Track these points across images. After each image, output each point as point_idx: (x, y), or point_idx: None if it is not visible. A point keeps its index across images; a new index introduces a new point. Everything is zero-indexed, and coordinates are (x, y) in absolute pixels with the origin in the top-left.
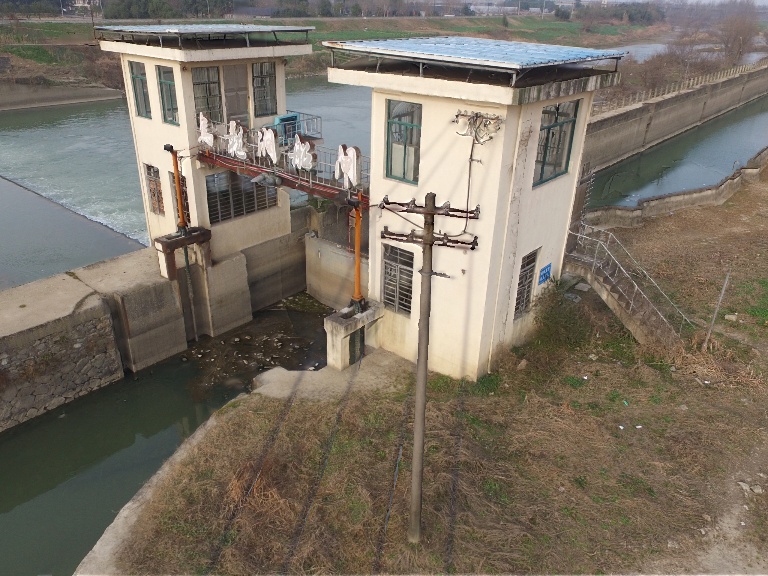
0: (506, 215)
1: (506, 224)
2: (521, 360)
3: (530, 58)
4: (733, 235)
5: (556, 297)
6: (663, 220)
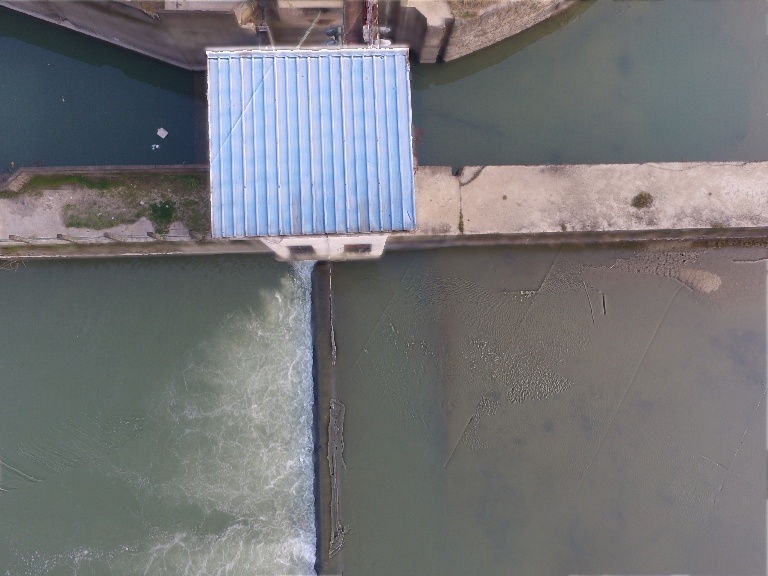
0: None
1: None
2: None
3: None
4: None
5: None
6: None
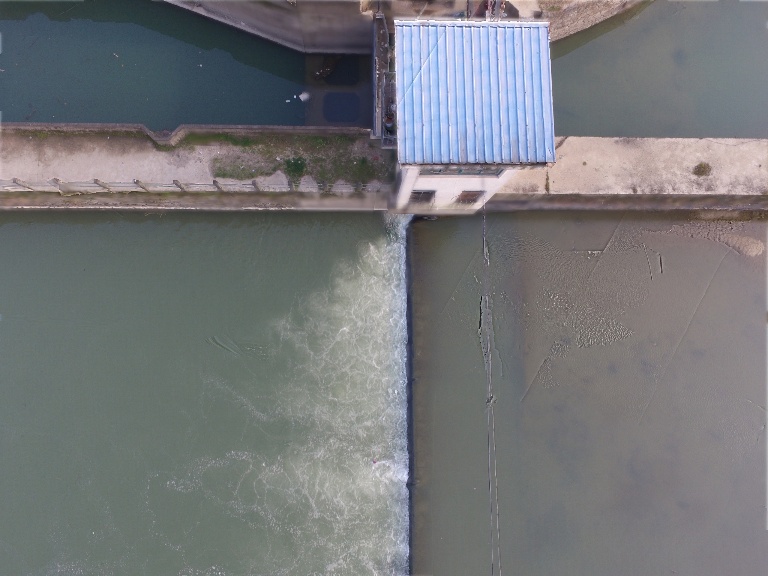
0: None
1: None
2: None
3: None
4: None
5: None
6: None
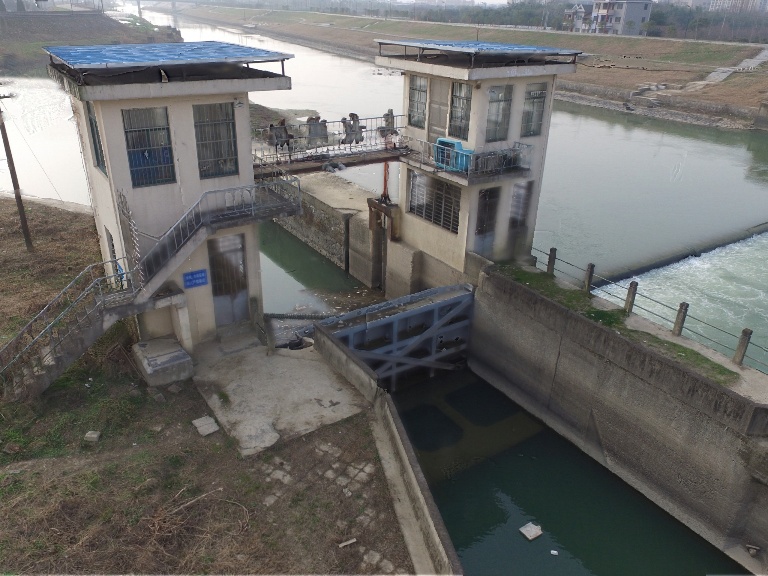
0: None
1: None
2: None
3: None
4: None
5: None
6: None
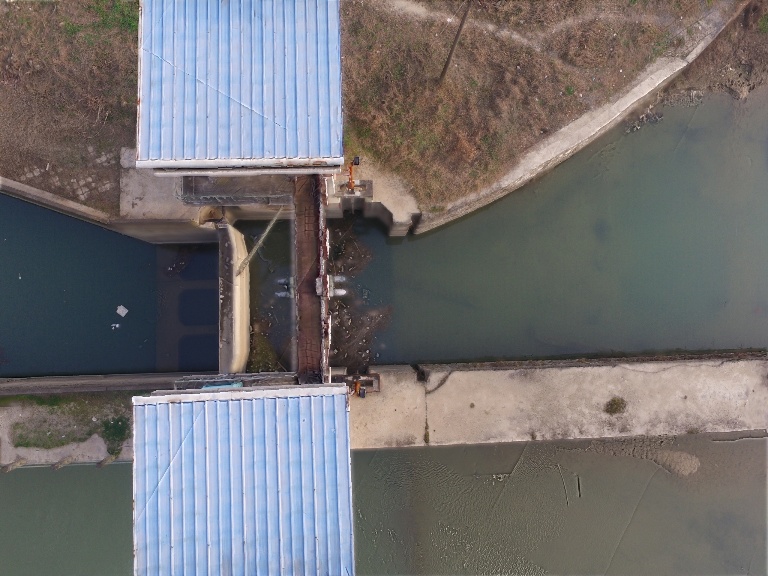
0: None
1: None
2: None
3: (291, 5)
4: None
5: None
6: None
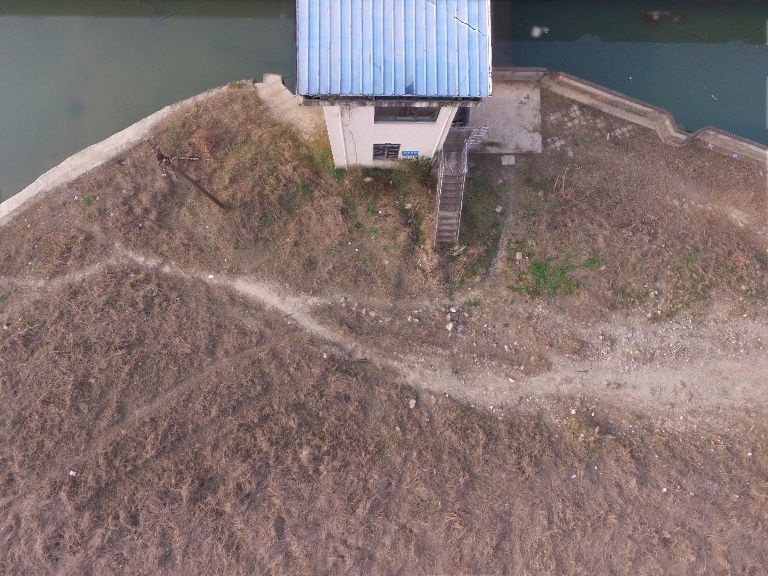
0: (340, 128)
1: (341, 131)
2: (369, 177)
3: (344, 76)
4: (716, 216)
5: (407, 168)
6: (709, 155)
